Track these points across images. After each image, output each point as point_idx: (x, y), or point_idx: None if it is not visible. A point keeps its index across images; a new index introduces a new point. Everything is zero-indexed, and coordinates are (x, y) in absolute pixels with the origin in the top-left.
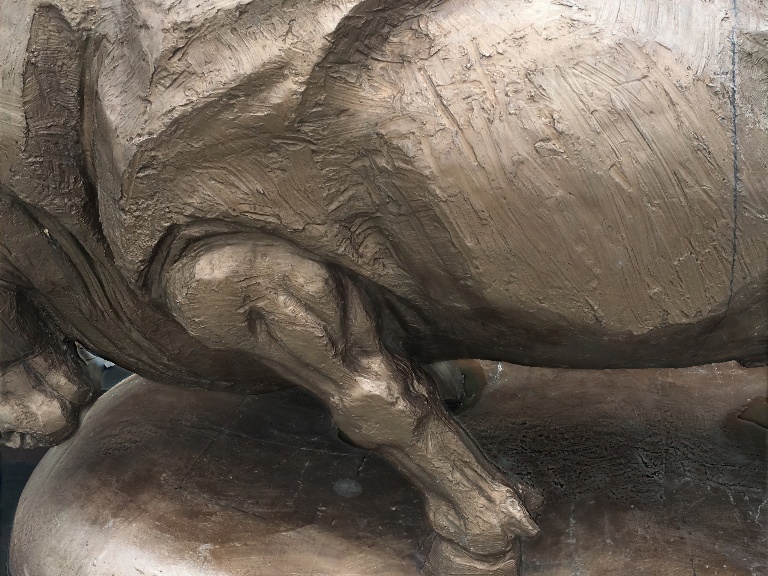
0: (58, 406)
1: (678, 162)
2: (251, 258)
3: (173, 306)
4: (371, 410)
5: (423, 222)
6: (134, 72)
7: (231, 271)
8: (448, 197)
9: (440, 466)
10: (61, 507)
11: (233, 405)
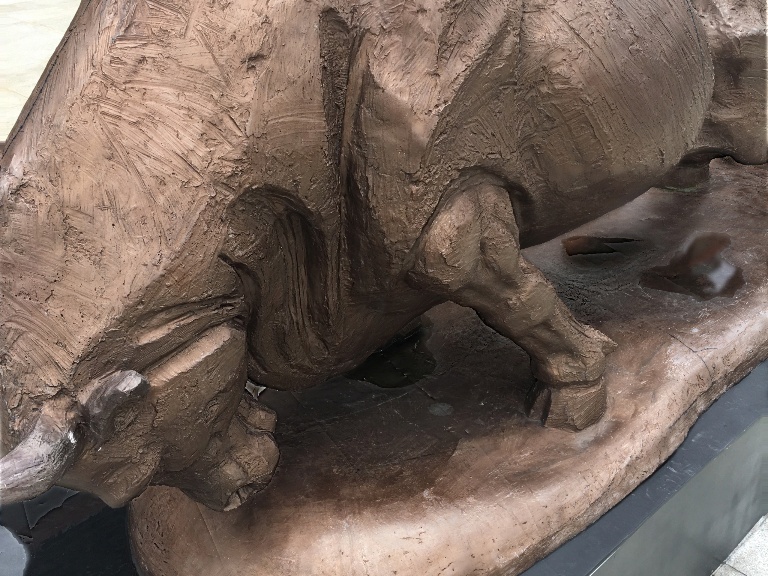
0: (269, 440)
1: (682, 42)
2: (477, 197)
3: (431, 263)
4: (537, 297)
5: (572, 127)
6: (414, 54)
7: (473, 212)
8: (593, 101)
9: (566, 325)
10: (278, 548)
11: (295, 405)
